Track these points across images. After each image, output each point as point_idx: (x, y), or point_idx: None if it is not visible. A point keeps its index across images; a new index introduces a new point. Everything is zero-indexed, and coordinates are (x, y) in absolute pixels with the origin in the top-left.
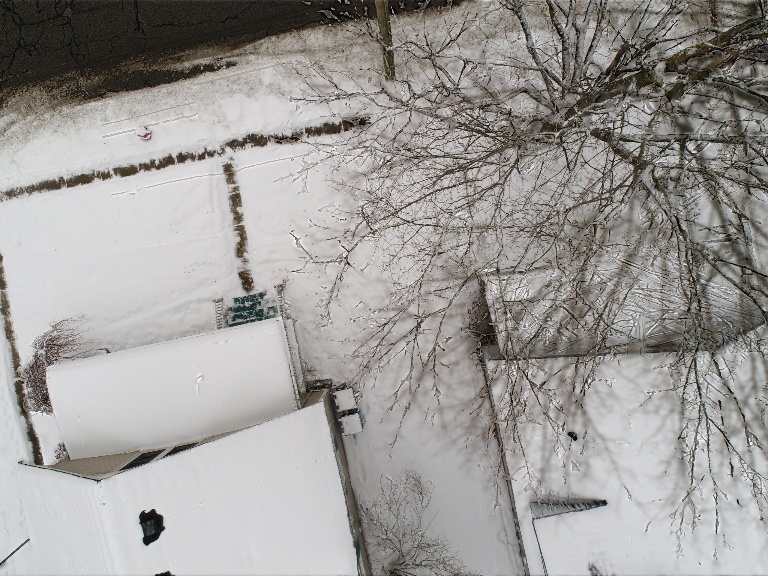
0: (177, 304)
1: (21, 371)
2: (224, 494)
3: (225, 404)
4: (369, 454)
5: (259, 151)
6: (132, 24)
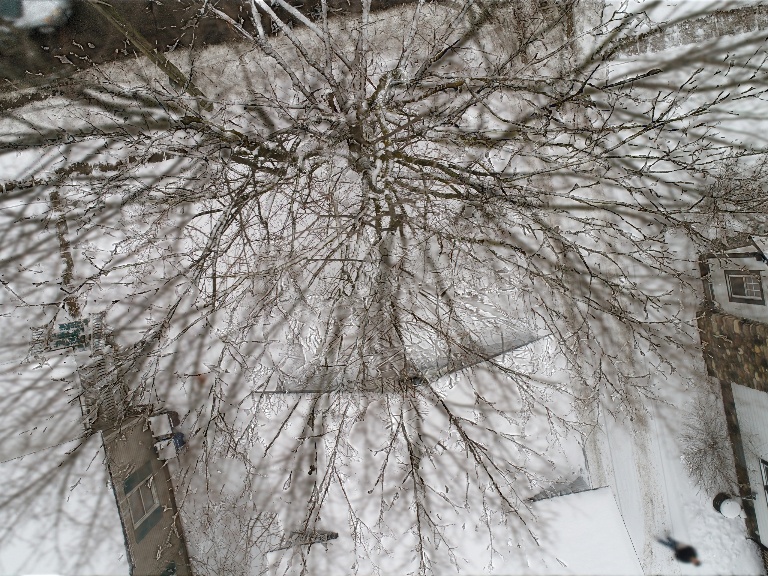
0: (3, 330)
1: None
2: None
3: (8, 435)
4: (193, 477)
5: (83, 179)
6: None
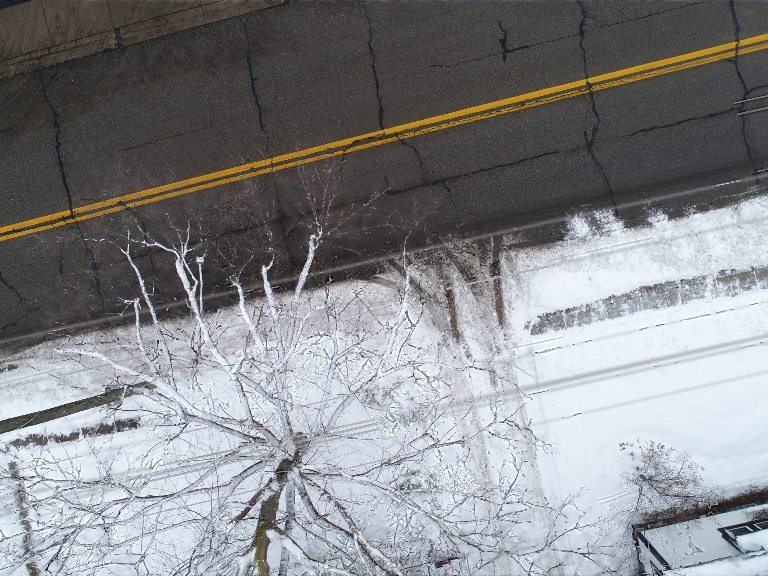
0: None
1: None
2: None
3: None
4: None
5: (39, 452)
6: None
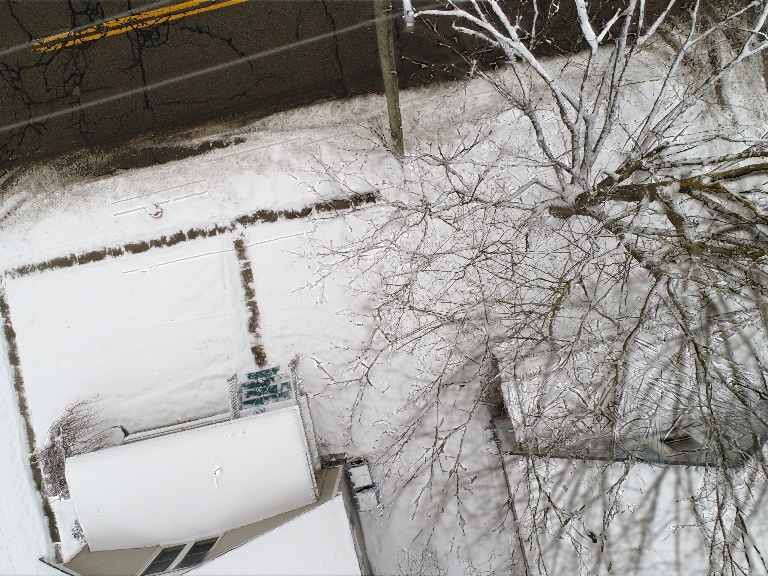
0: (191, 381)
1: (36, 446)
2: None
3: (244, 497)
4: (384, 526)
5: (270, 227)
6: (141, 102)
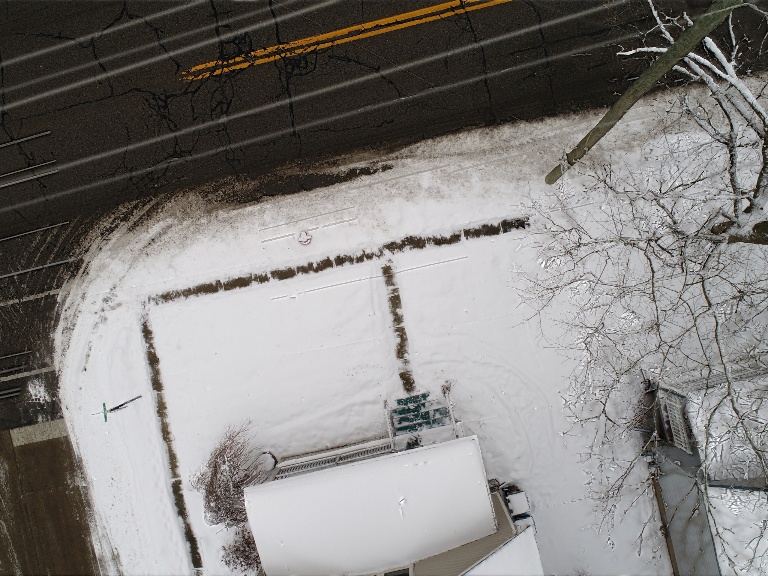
0: (341, 407)
1: (178, 472)
2: None
3: (431, 528)
4: None
5: (419, 254)
6: (288, 130)
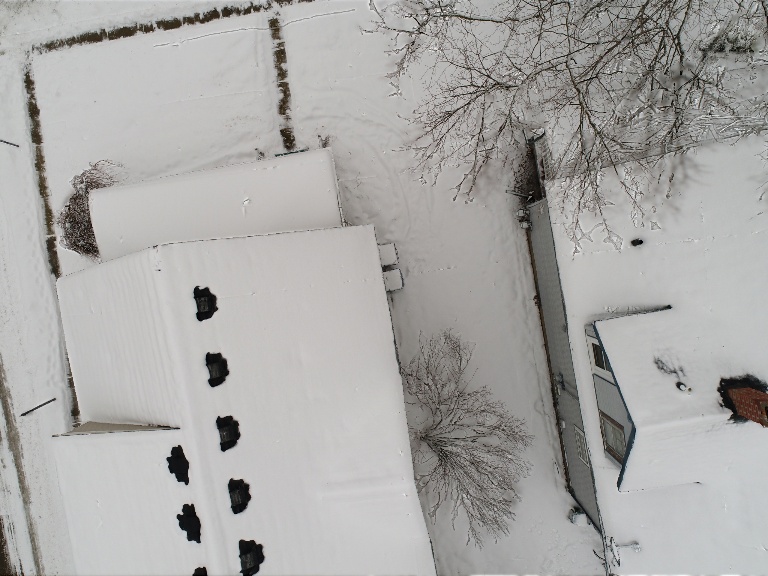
0: (217, 158)
1: (54, 228)
2: (276, 290)
3: (272, 227)
4: (406, 319)
5: (306, 5)
6: None
